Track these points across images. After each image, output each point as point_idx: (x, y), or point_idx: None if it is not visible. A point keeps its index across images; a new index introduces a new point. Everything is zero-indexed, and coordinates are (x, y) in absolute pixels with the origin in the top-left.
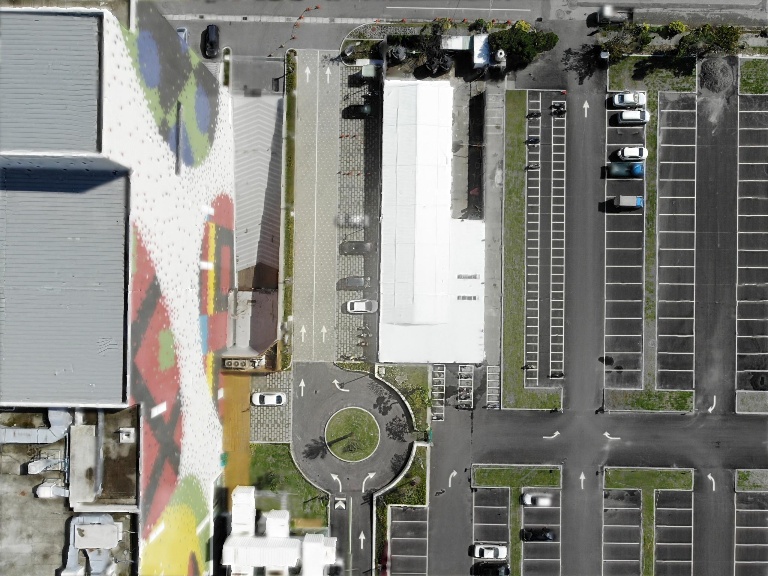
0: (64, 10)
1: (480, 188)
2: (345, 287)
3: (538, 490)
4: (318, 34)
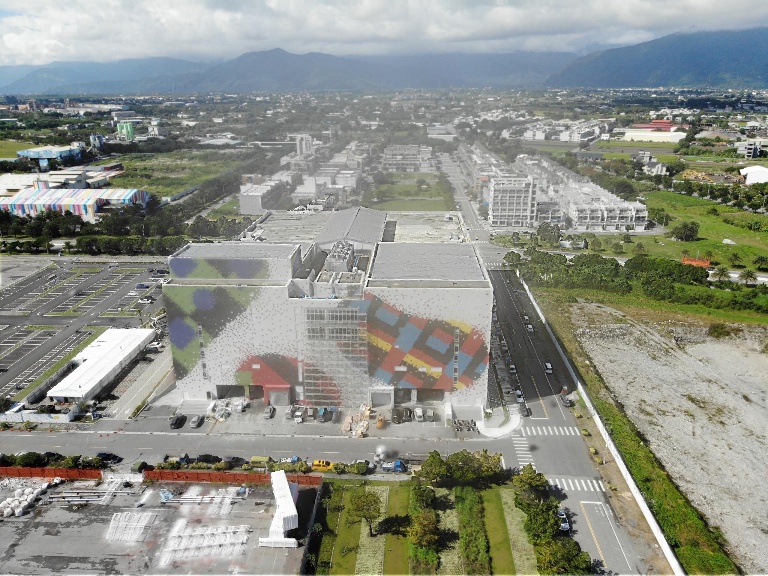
0: (183, 258)
1: (65, 374)
2: (159, 351)
3: (114, 312)
4: (110, 426)
